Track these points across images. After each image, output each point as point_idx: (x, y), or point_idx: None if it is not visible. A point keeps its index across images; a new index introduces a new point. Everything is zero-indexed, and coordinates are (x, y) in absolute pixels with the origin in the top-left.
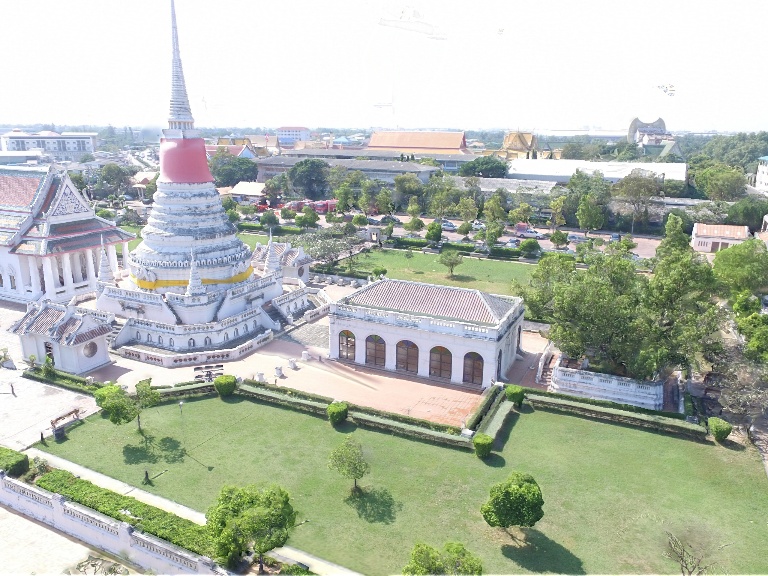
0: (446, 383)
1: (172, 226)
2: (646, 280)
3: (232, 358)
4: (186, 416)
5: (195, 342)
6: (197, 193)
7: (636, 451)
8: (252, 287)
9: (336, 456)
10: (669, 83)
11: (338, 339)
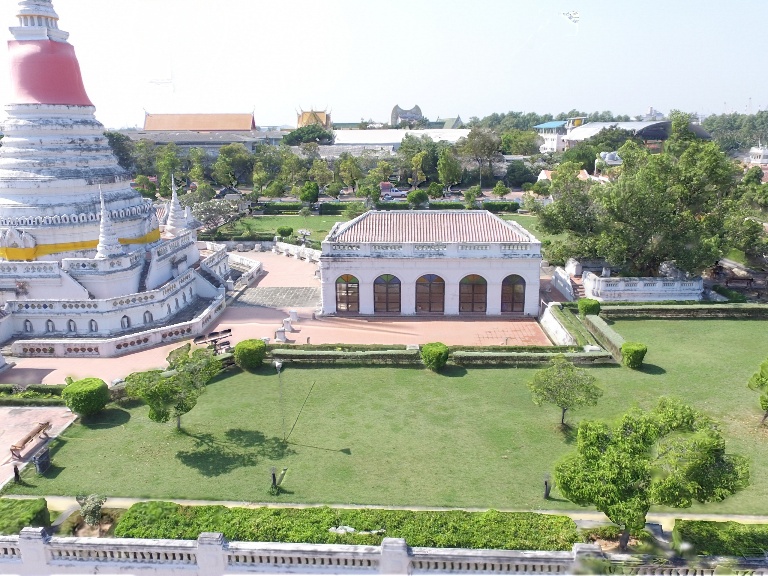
0: (483, 317)
1: (48, 166)
2: (680, 172)
3: (195, 333)
4: (225, 400)
5: (130, 321)
6: (79, 120)
7: (749, 336)
8: (173, 247)
9: (551, 384)
10: (573, 10)
11: (334, 288)
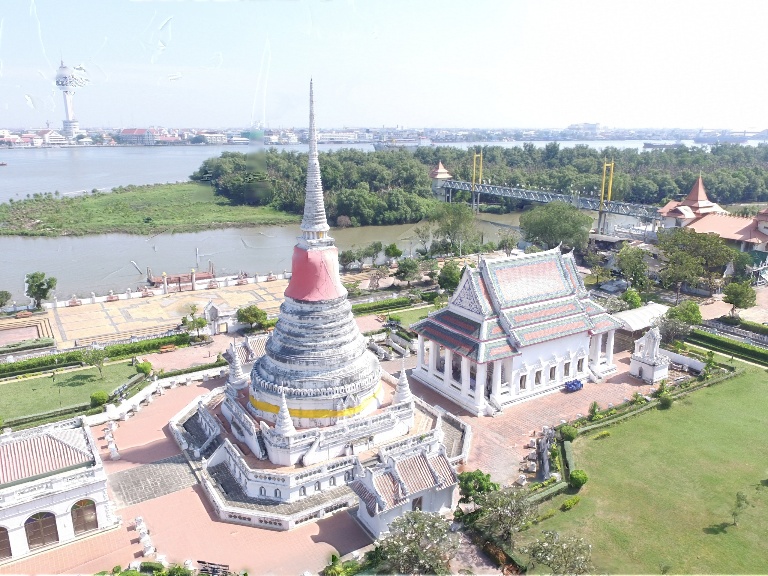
0: None
1: None
2: None
3: None
4: None
5: None
6: None
7: None
8: None
9: None
10: None
11: None
